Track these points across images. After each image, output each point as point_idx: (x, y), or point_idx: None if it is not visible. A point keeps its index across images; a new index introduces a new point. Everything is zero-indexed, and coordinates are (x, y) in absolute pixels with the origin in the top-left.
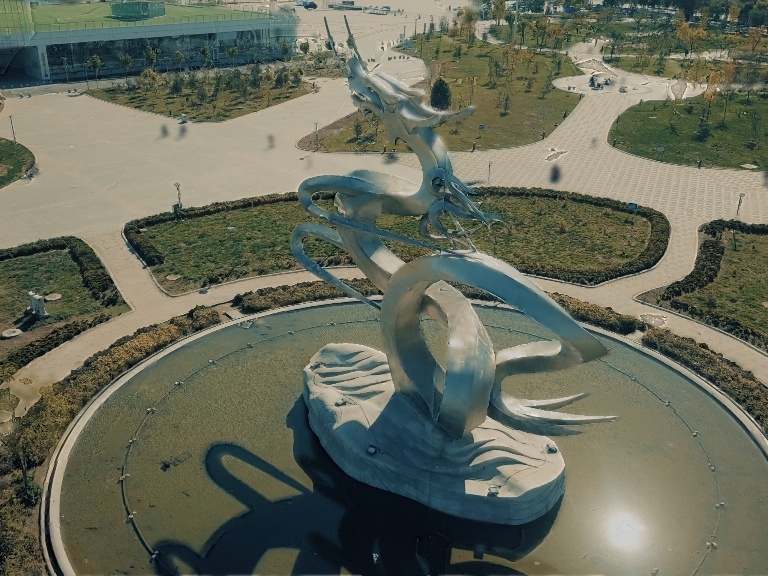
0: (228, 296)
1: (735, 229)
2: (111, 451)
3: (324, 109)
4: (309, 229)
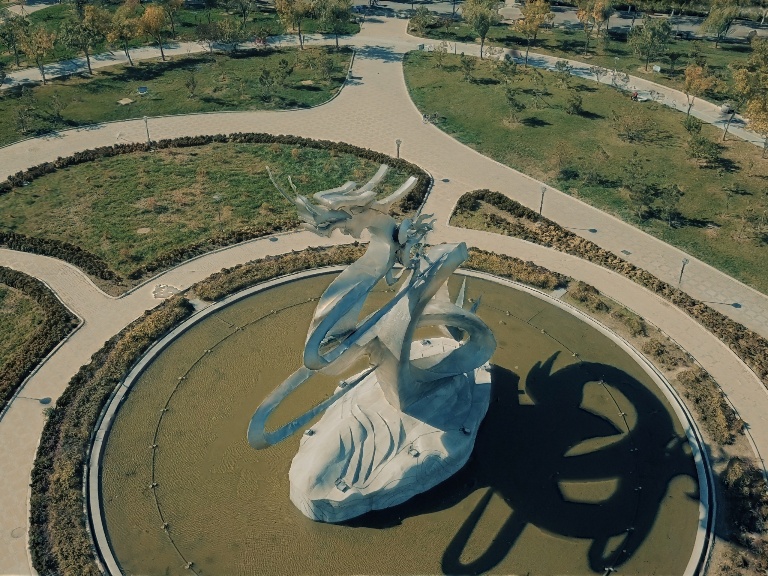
0: None
1: None
2: None
3: None
4: (273, 404)
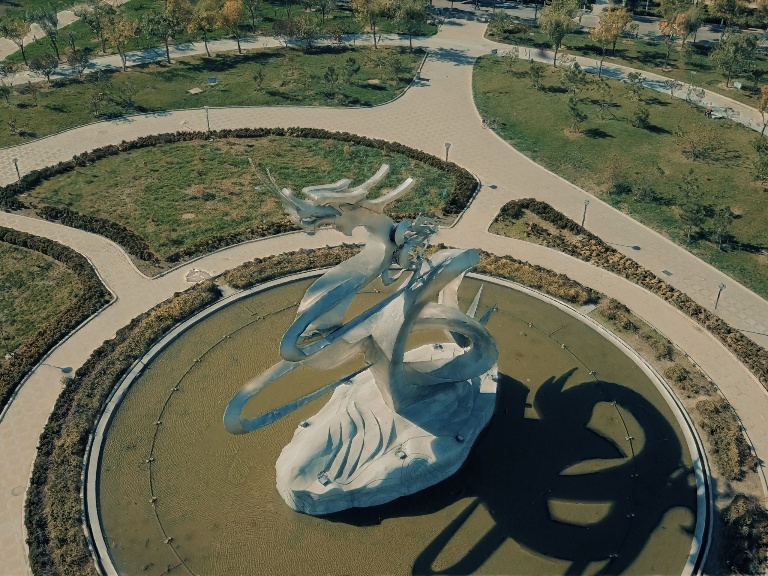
0: None
1: (23, 192)
2: None
3: None
4: (252, 392)
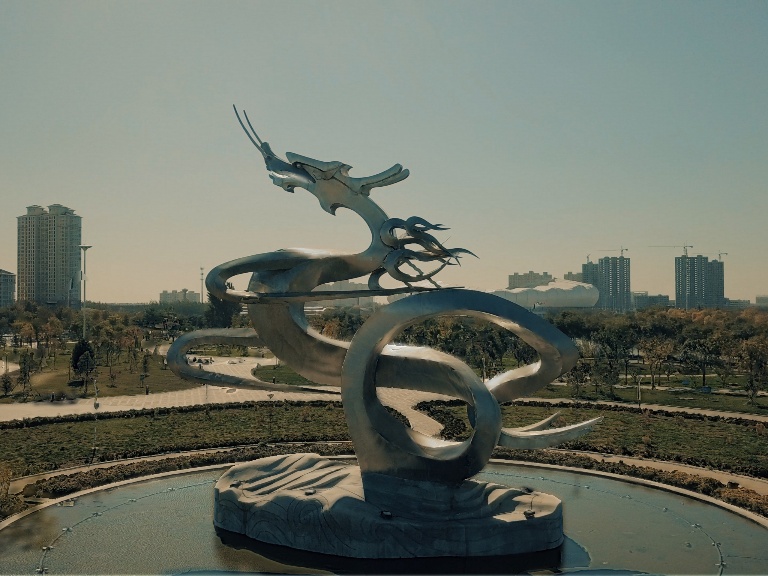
0: (10, 491)
1: (441, 405)
2: None
3: None
4: (200, 335)
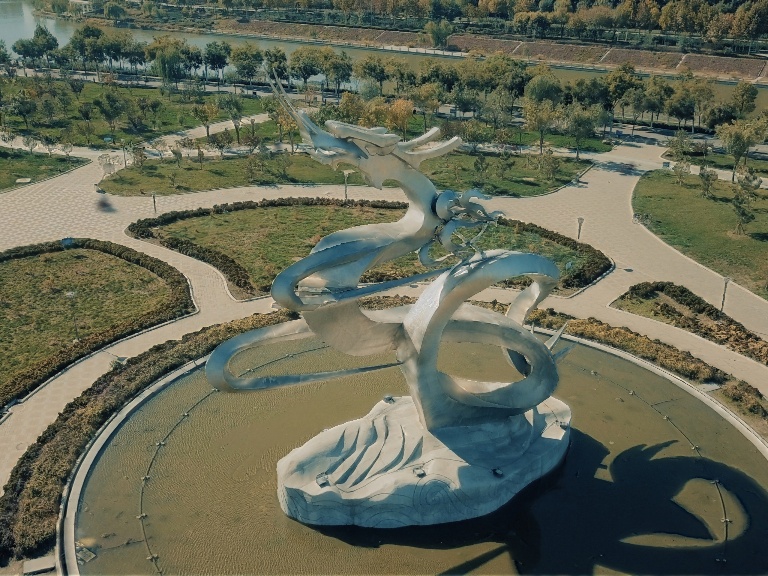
0: None
1: (157, 225)
2: None
3: None
4: (243, 343)
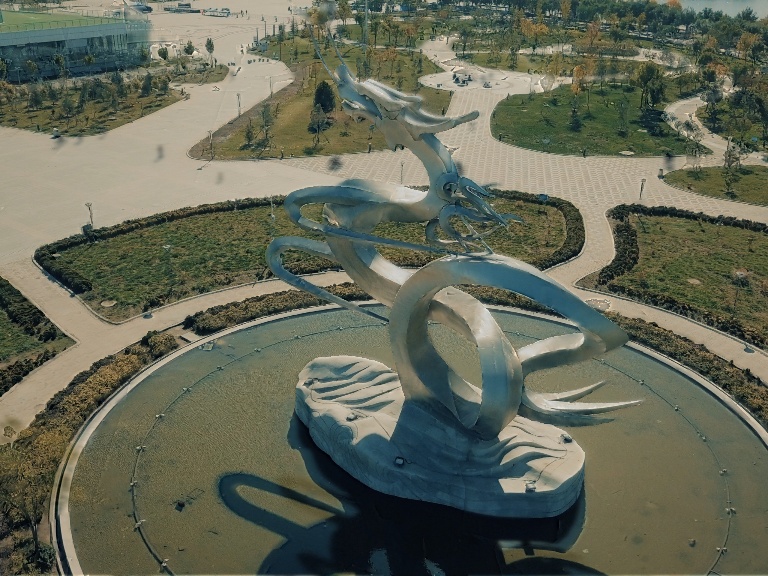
0: (177, 318)
1: (639, 212)
2: (113, 497)
3: (202, 116)
4: (289, 242)
